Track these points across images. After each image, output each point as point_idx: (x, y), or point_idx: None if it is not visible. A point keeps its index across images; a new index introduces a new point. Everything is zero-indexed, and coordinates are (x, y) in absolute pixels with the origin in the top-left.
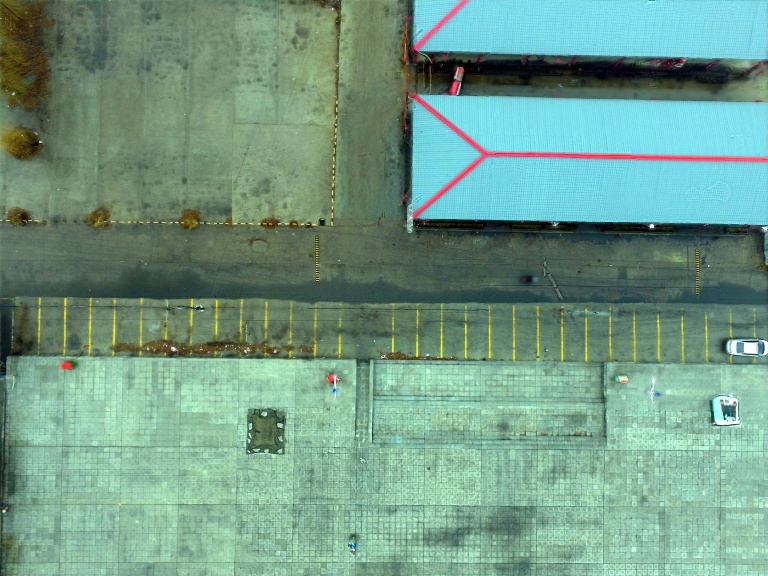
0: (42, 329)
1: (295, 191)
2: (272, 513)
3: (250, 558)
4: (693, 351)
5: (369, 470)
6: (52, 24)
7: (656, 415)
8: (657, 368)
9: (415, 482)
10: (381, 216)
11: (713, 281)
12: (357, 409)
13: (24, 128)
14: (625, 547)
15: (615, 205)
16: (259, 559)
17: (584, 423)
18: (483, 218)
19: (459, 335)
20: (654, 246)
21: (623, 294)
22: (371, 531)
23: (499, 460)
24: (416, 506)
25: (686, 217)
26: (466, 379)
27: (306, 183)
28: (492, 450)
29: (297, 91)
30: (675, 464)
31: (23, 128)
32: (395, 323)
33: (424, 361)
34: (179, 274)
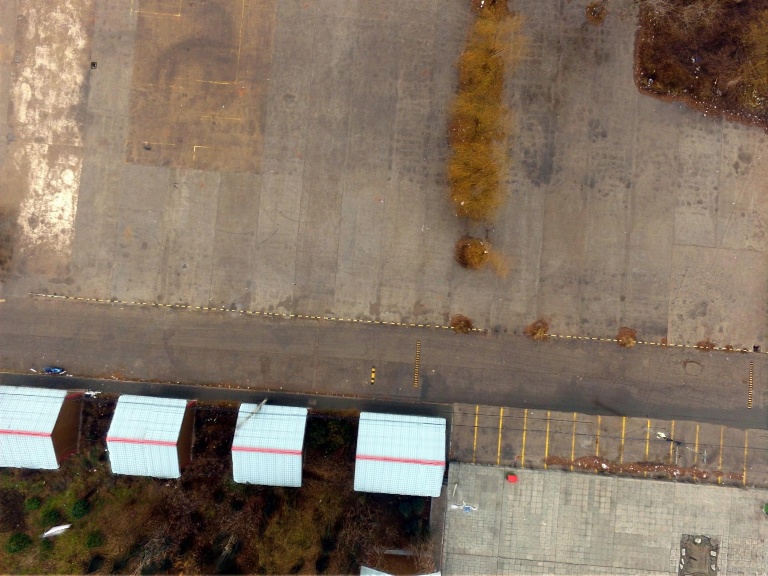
0: (478, 437)
1: (732, 316)
2: None
3: None
4: None
5: None
6: (502, 137)
7: None
8: None
9: None
10: None
11: None
12: None
13: (471, 237)
14: None
15: None
16: None
17: None
18: None
19: None
20: None
21: None
22: None
23: None
24: None
25: None
26: None
27: (743, 308)
28: None
29: (737, 216)
30: None
31: (470, 237)
32: None
33: None
34: (613, 391)
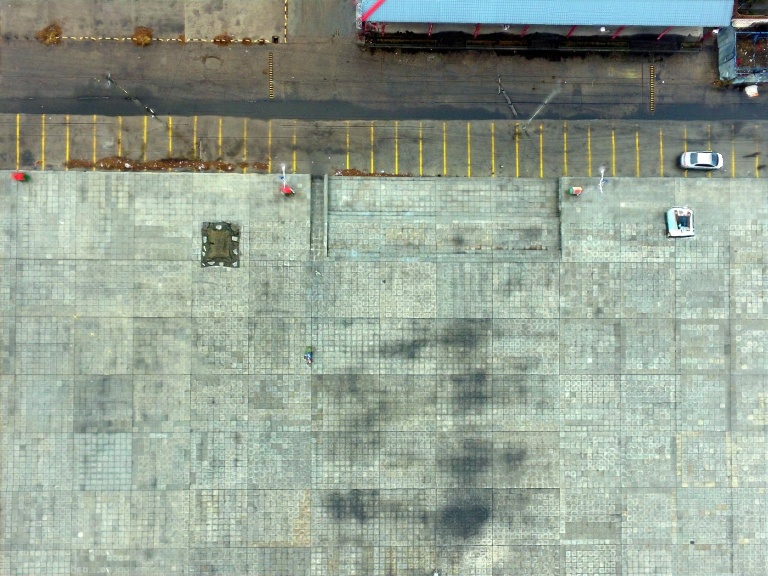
0: None
1: (248, 8)
2: (228, 326)
3: (206, 370)
4: (648, 167)
5: (324, 283)
6: None
7: (611, 228)
8: (611, 181)
9: (371, 295)
10: (335, 33)
11: (668, 97)
12: (312, 224)
13: None
14: (581, 358)
15: (564, 2)
16: (215, 371)
17: (539, 237)
18: (433, 20)
19: (414, 152)
20: (608, 63)
21: (578, 111)
22: (327, 343)
23: (454, 273)
24: (372, 319)
25: (635, 12)
26: (421, 194)
27: (259, 0)
28: (447, 263)
29: None
30: (630, 276)
31: None
32: (350, 140)
33: (379, 177)
34: (132, 91)
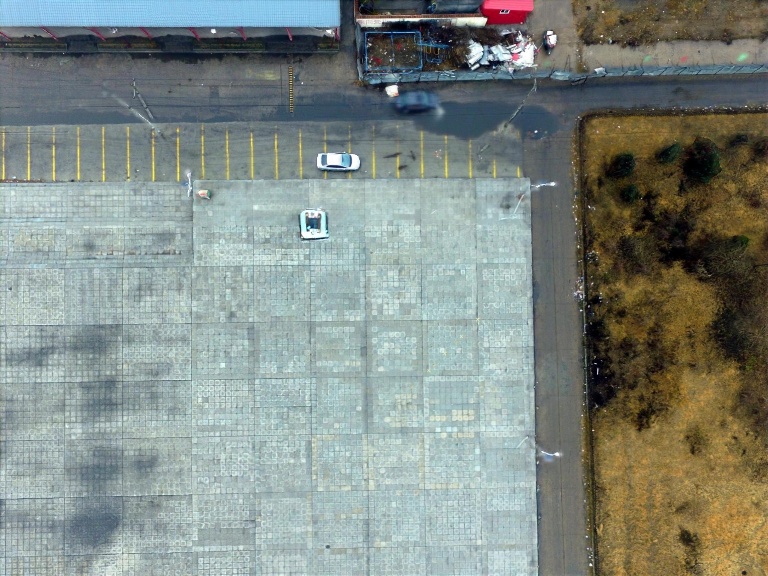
0: None
1: None
2: None
3: None
4: (287, 169)
5: None
6: None
7: (244, 231)
8: (244, 184)
9: None
10: None
11: (307, 99)
12: None
13: None
14: (214, 363)
15: (160, 4)
16: None
17: (173, 241)
18: (36, 24)
19: (47, 157)
20: (246, 64)
21: (215, 113)
22: None
23: (83, 279)
24: None
25: (229, 14)
26: (52, 200)
27: None
28: (76, 269)
29: None
30: (264, 279)
31: None
32: None
33: (9, 183)
34: None
